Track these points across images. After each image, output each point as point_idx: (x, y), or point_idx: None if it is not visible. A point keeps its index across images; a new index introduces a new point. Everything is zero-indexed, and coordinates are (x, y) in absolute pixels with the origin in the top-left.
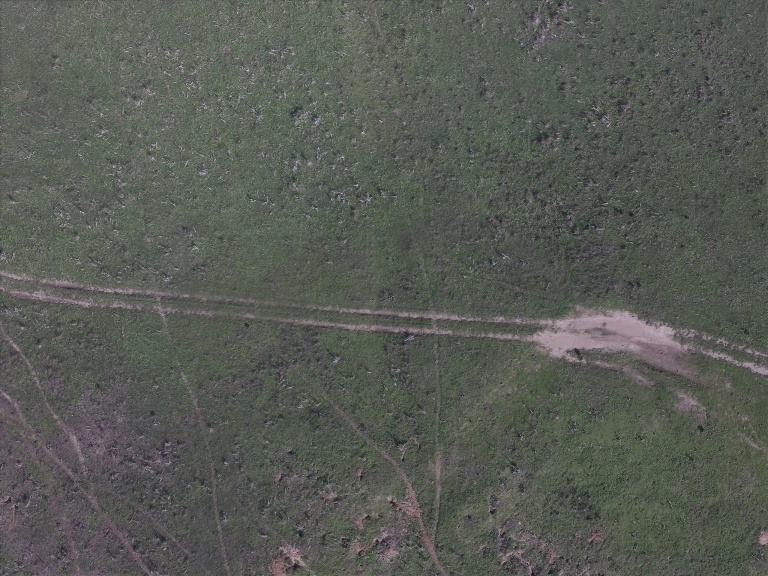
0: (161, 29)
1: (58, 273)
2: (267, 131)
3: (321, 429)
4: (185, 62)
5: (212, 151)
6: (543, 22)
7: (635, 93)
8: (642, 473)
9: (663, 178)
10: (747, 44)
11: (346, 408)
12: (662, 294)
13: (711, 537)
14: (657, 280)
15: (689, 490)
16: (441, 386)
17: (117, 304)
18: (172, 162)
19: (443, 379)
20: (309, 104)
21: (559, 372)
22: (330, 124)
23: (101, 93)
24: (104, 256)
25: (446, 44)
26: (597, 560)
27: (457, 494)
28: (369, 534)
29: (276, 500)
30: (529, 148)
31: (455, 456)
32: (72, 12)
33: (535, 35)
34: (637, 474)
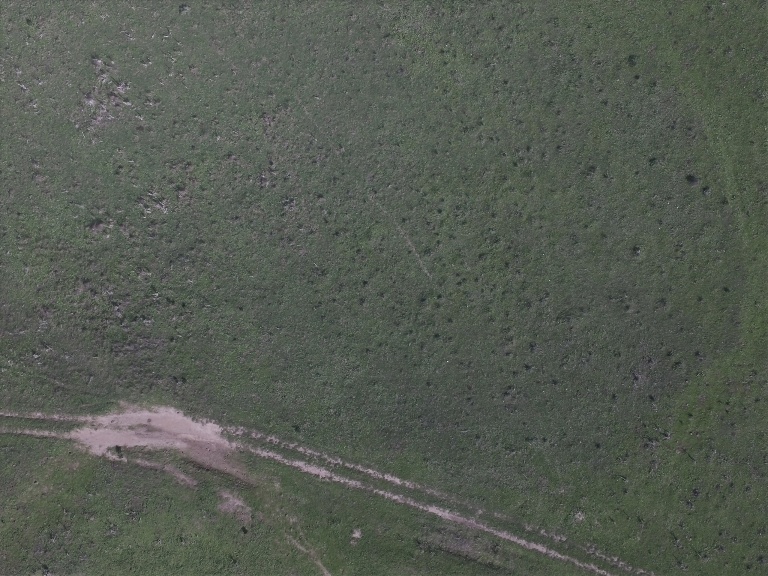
0: None
1: None
2: None
3: None
4: None
5: None
6: (101, 103)
7: (194, 178)
8: (184, 575)
9: (220, 267)
10: (315, 128)
11: None
12: (209, 390)
13: None
14: (205, 375)
15: None
16: None
17: None
18: None
19: None
20: None
21: (97, 471)
22: None
23: None
24: None
25: None
26: None
27: None
28: None
29: None
30: (82, 234)
31: None
32: None
33: (92, 116)
34: None
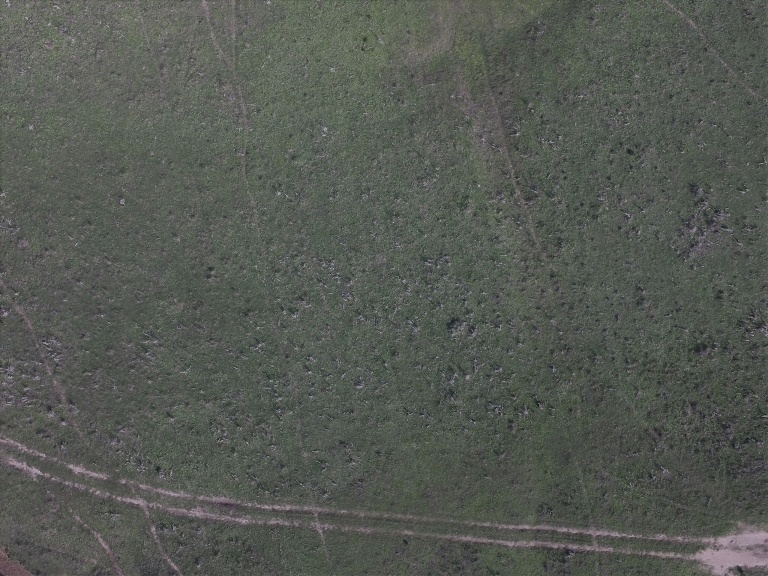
0: (316, 239)
1: (215, 489)
2: (424, 342)
3: None
4: (341, 272)
5: (368, 363)
6: (699, 229)
7: None
8: None
9: None
10: None
11: None
12: None
13: None
14: None
15: None
16: None
17: (274, 520)
18: (328, 375)
19: None
20: (466, 315)
21: None
22: (487, 335)
23: (257, 305)
24: (261, 471)
25: (602, 252)
26: None
27: None
28: None
29: None
30: (686, 357)
31: None
32: (227, 222)
33: (691, 242)
34: None
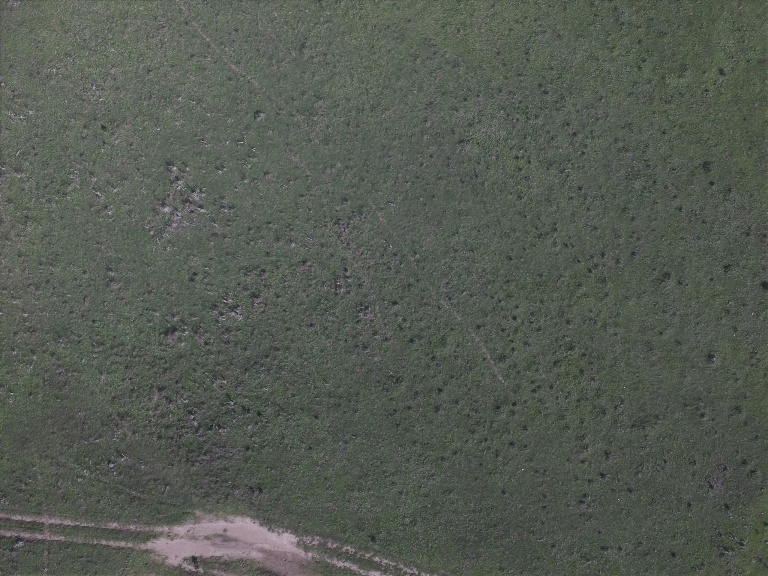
0: None
1: None
2: None
3: None
4: None
5: None
6: (175, 209)
7: (269, 285)
8: None
9: (295, 375)
10: (389, 234)
11: None
12: (285, 499)
13: None
14: (281, 485)
15: None
16: None
17: None
18: None
19: None
20: None
21: None
22: None
23: None
24: None
25: (72, 232)
26: None
27: None
28: None
29: None
30: (157, 341)
31: None
32: None
33: (166, 223)
34: None
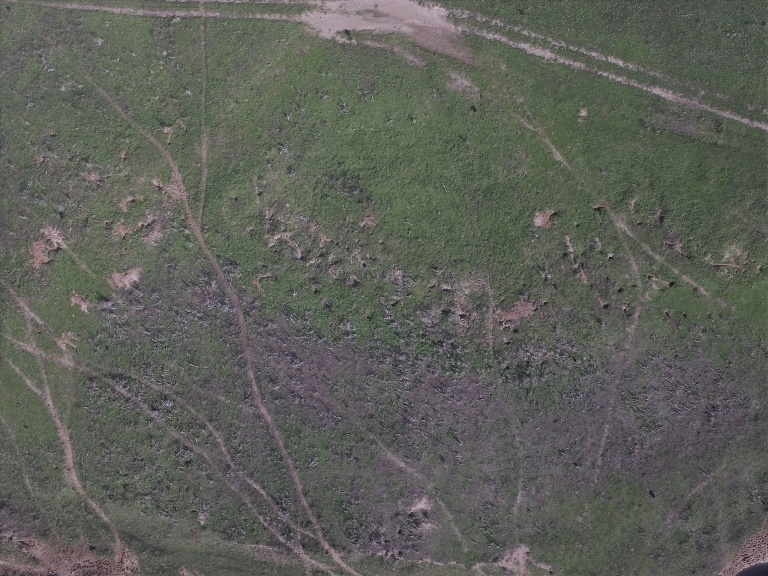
0: None
1: None
2: None
3: (83, 111)
4: None
5: None
6: None
7: None
8: (415, 156)
9: None
10: None
11: (109, 90)
12: None
13: (486, 220)
14: None
15: (463, 173)
16: (207, 67)
17: None
18: None
19: (208, 59)
20: None
21: (328, 52)
22: None
23: None
24: None
25: None
26: (368, 243)
27: (223, 176)
28: (133, 217)
29: (37, 182)
30: None
31: (222, 138)
32: None
33: None
34: (410, 157)
